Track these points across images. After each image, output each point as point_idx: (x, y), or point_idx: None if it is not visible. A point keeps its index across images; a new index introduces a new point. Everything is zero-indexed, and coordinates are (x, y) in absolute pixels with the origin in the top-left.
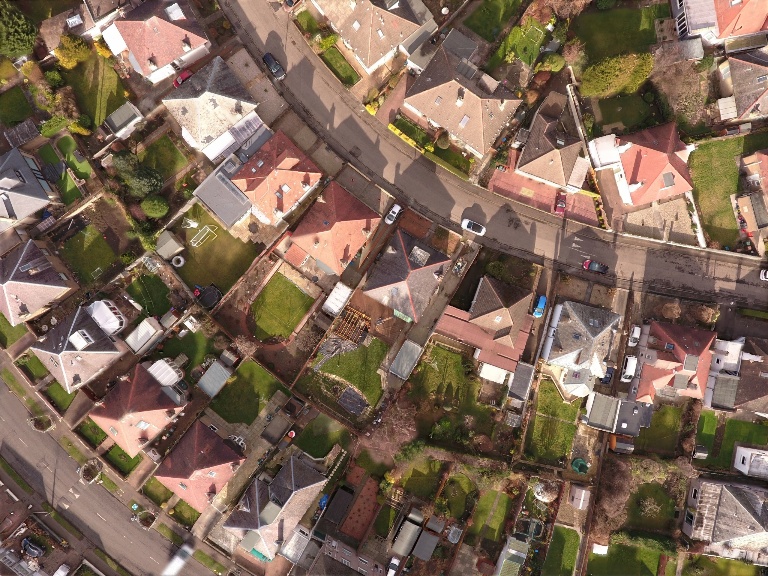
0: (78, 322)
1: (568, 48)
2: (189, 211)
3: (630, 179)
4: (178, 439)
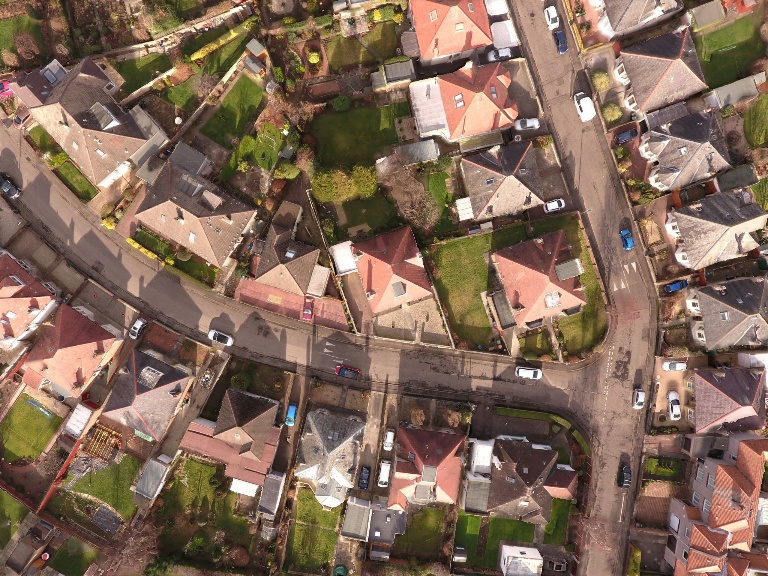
0: None
1: (300, 155)
2: None
3: (366, 287)
4: None
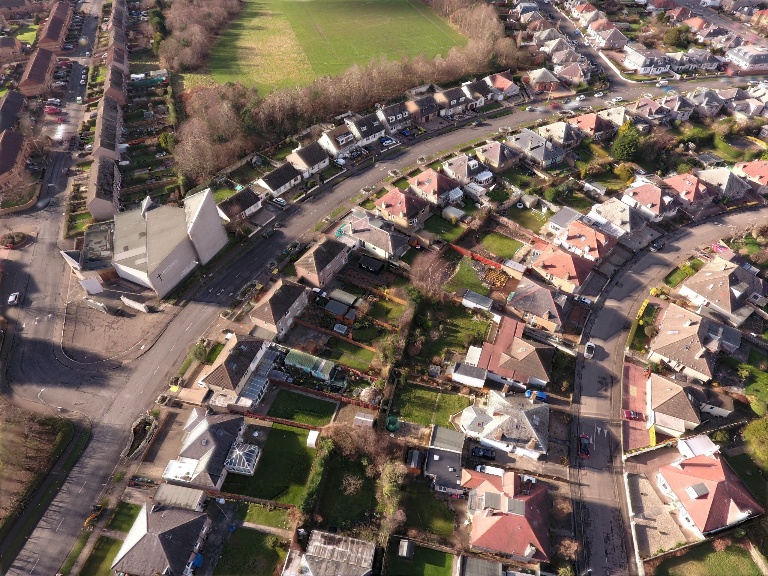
0: (481, 165)
1: None
2: (551, 211)
3: (684, 462)
4: None
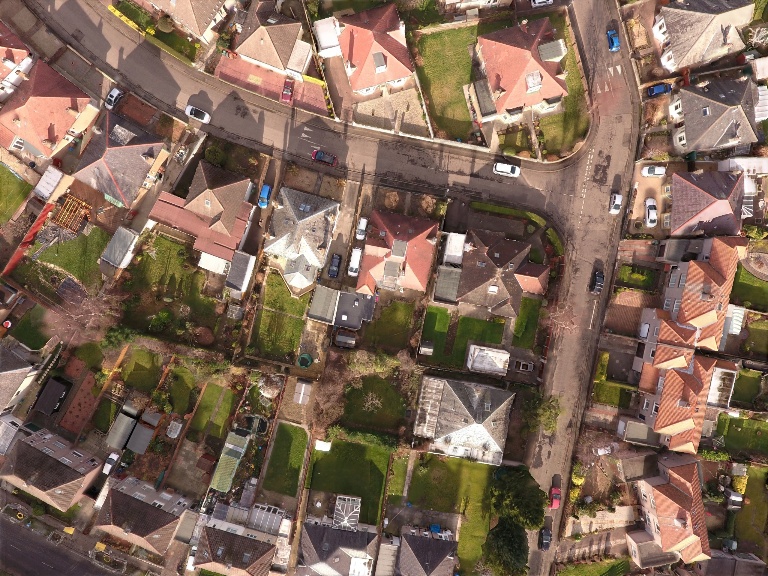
0: None
1: None
2: None
3: None
4: None
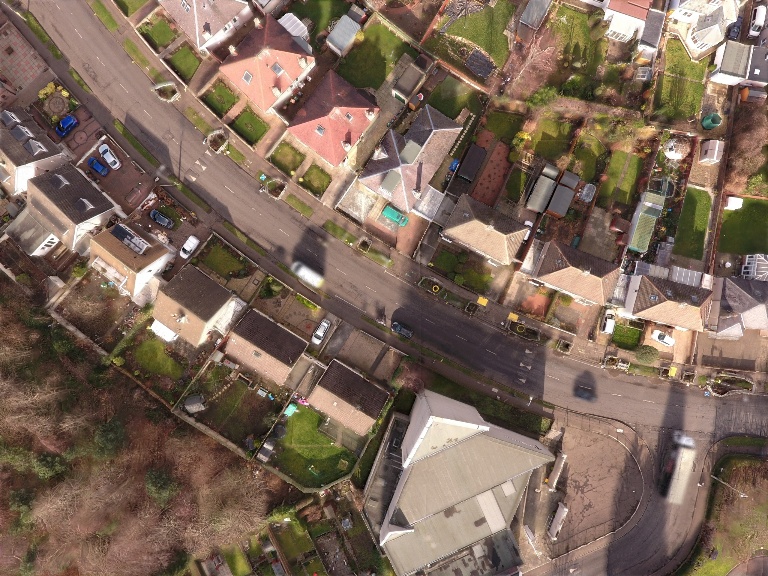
0: None
1: None
2: None
3: None
4: None
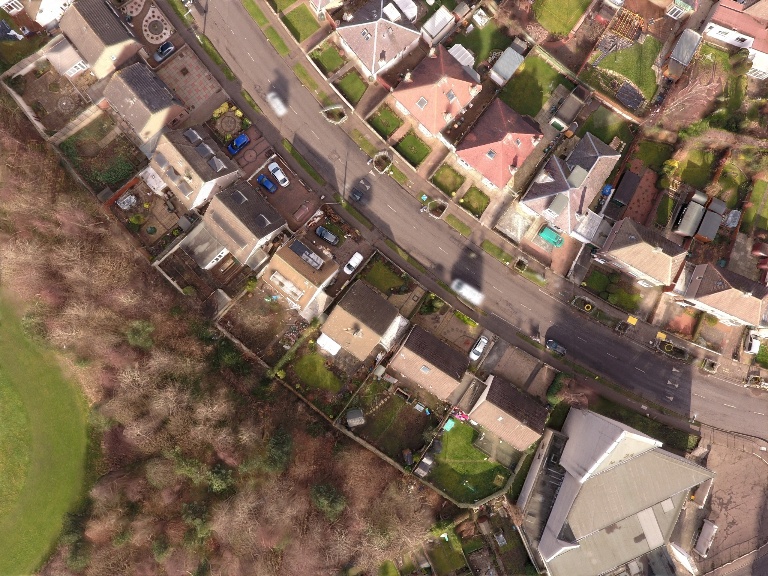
0: (385, 0)
1: None
2: None
3: None
4: (468, 128)
